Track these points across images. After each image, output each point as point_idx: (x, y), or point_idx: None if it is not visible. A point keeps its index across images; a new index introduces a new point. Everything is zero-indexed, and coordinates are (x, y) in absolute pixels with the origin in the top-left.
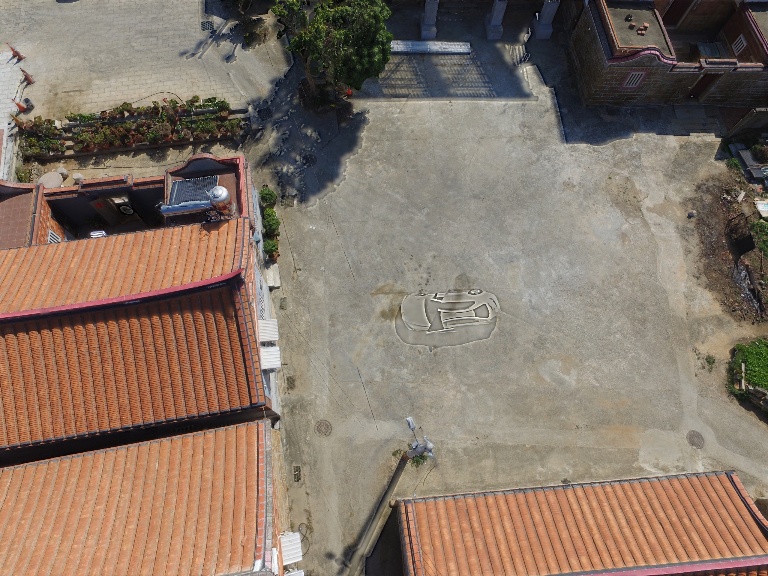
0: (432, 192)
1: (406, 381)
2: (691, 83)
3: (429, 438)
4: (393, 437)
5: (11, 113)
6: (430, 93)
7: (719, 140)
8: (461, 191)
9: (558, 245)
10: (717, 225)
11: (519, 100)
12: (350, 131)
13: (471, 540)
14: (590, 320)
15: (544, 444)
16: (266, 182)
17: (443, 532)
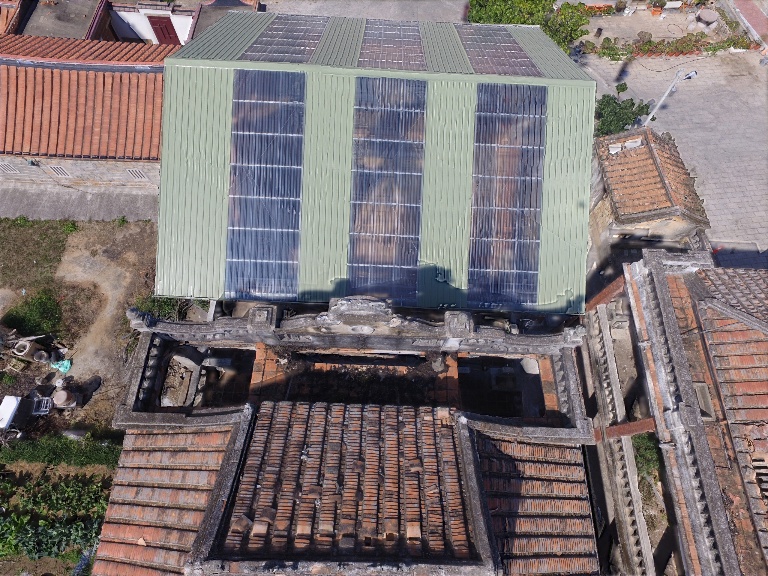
0: (422, 4)
1: None
2: None
3: None
4: None
5: None
6: None
7: None
8: (399, 2)
9: None
10: None
11: None
12: None
13: None
14: None
15: None
16: None
17: None
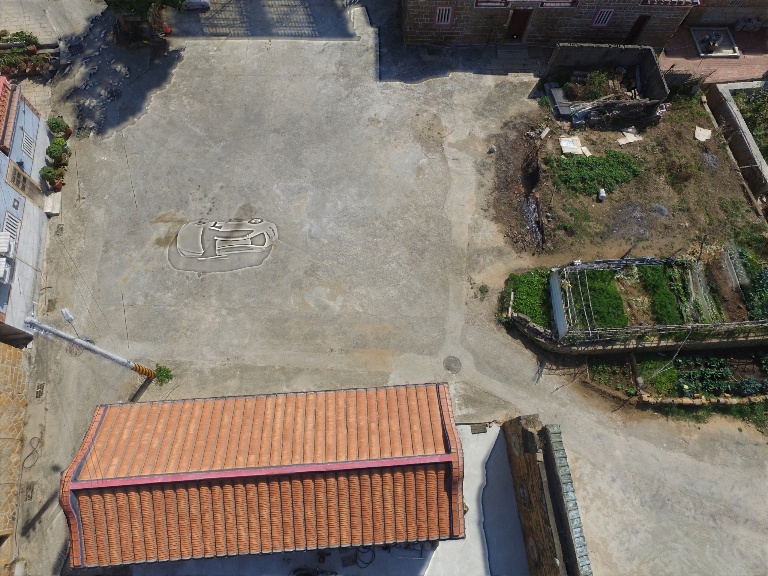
0: (232, 126)
1: (168, 305)
2: (504, 20)
3: (179, 358)
4: (143, 357)
5: None
6: (251, 32)
7: (537, 80)
8: (262, 125)
9: (350, 178)
10: (515, 160)
11: (340, 40)
12: (162, 67)
13: (148, 439)
14: (368, 249)
15: (294, 366)
16: (66, 115)
17: (123, 432)
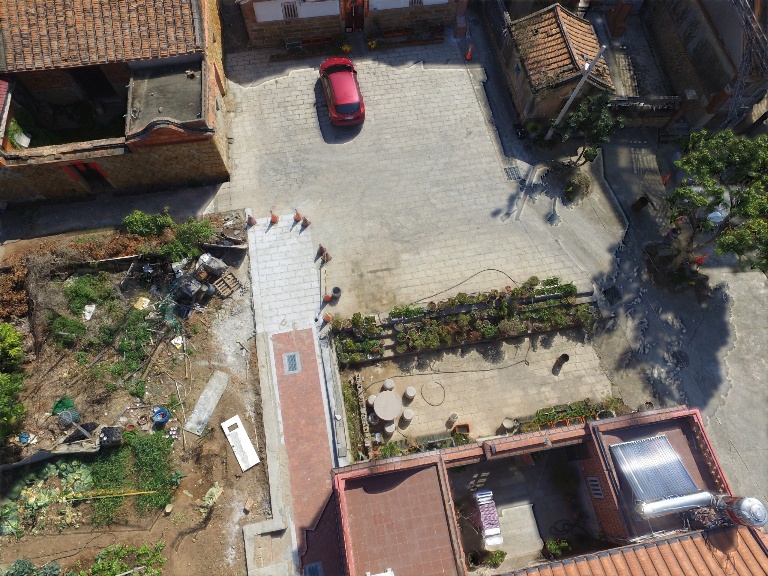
0: None
1: None
2: None
3: None
4: None
5: (314, 304)
6: None
7: None
8: None
9: None
10: None
11: None
12: (715, 315)
13: None
14: None
15: None
16: (638, 393)
17: None
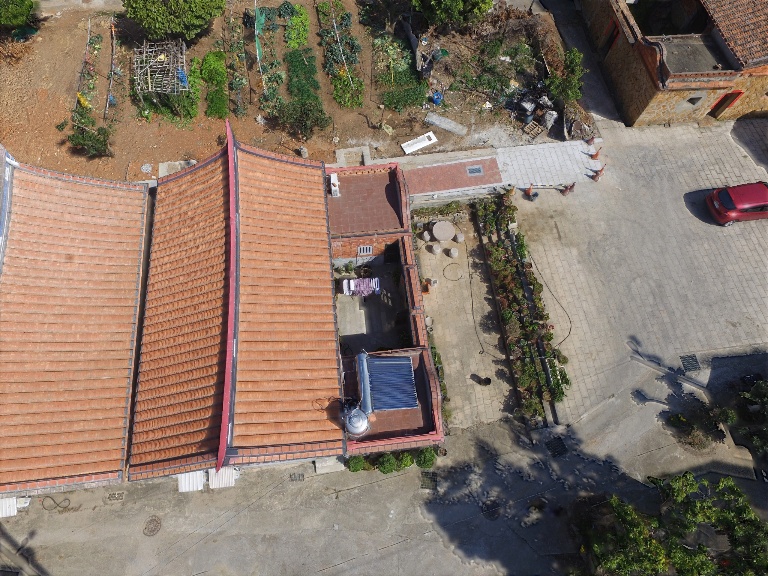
0: None
1: None
2: None
3: None
4: None
5: (523, 184)
6: None
7: None
8: None
9: None
10: None
11: None
12: (545, 573)
13: None
14: None
15: None
16: (456, 451)
17: None
